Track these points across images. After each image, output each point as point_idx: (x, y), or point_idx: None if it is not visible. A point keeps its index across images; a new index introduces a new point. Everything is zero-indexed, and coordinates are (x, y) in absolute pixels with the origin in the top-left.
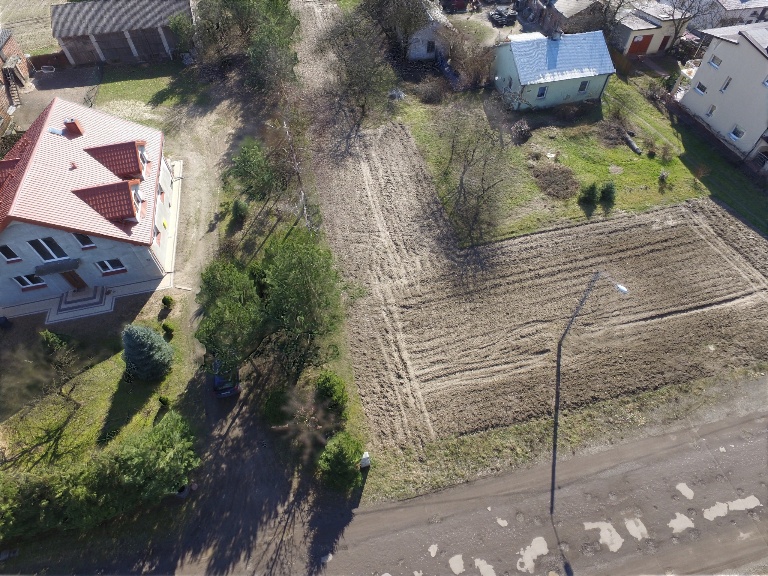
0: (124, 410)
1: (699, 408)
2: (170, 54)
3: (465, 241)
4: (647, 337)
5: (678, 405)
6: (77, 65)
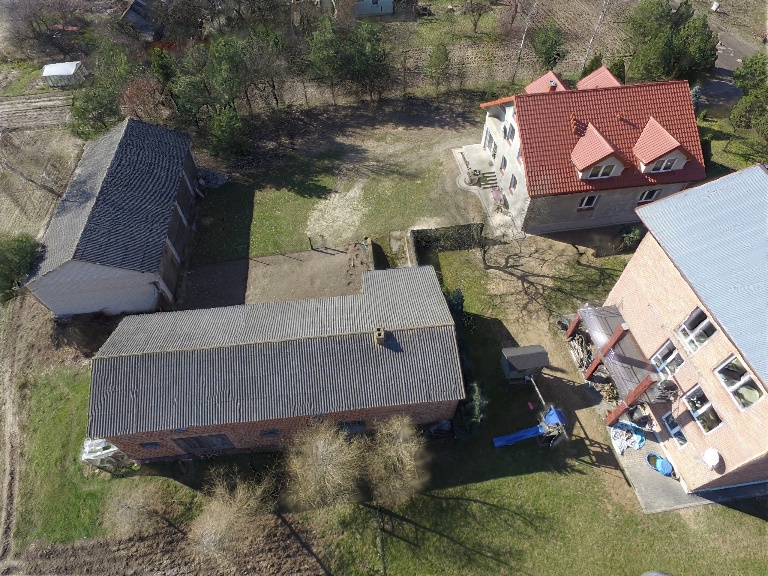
0: (715, 134)
1: (623, 1)
2: (198, 192)
3: (537, 35)
4: (591, 3)
5: (624, 4)
6: (174, 296)
